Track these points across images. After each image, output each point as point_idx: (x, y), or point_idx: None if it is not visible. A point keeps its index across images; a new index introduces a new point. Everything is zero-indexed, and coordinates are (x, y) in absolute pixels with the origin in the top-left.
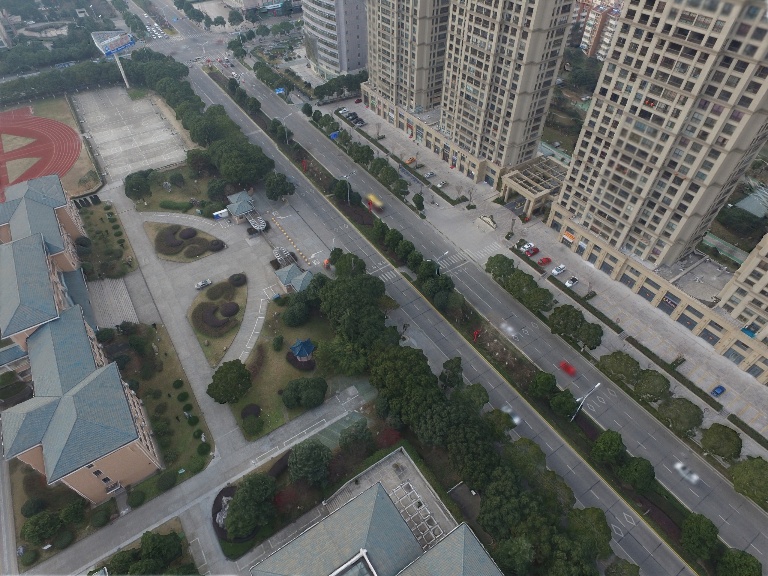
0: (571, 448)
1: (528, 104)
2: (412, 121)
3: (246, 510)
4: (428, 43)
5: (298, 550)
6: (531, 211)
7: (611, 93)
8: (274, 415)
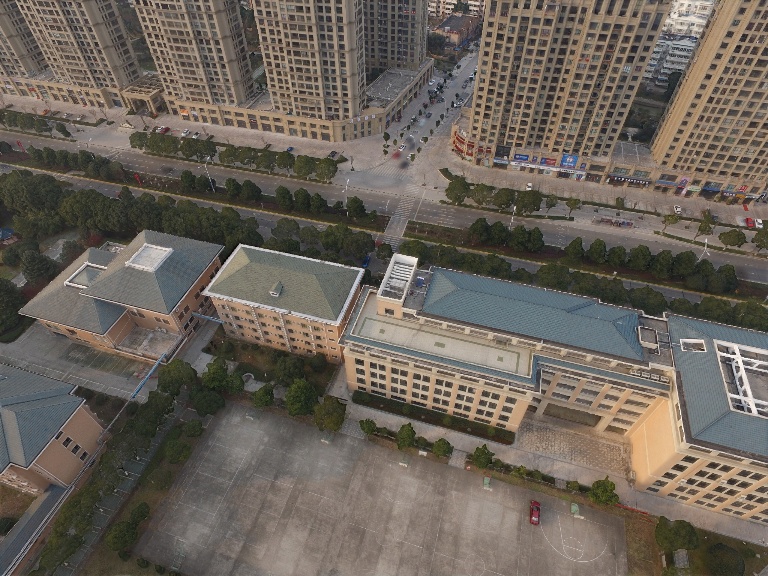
0: (218, 203)
1: (106, 32)
2: (30, 83)
3: (1, 302)
4: (4, 13)
5: (47, 289)
6: (154, 108)
7: (142, 1)
8: (3, 276)
